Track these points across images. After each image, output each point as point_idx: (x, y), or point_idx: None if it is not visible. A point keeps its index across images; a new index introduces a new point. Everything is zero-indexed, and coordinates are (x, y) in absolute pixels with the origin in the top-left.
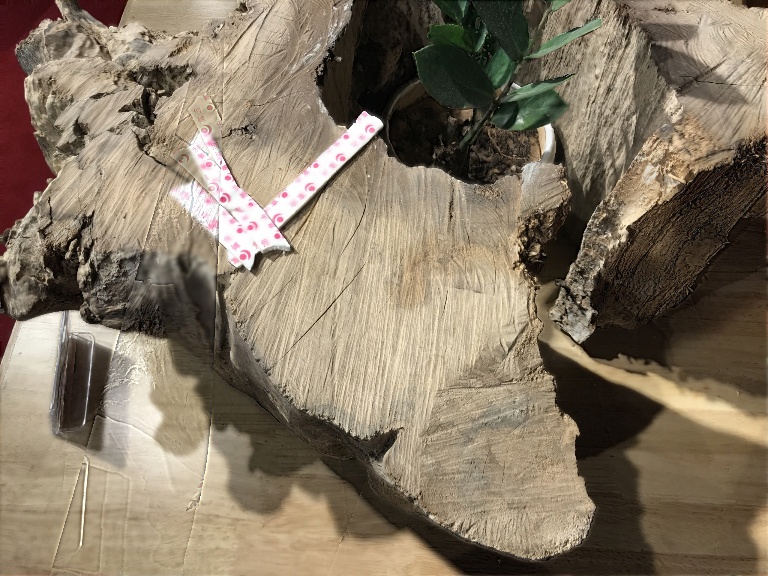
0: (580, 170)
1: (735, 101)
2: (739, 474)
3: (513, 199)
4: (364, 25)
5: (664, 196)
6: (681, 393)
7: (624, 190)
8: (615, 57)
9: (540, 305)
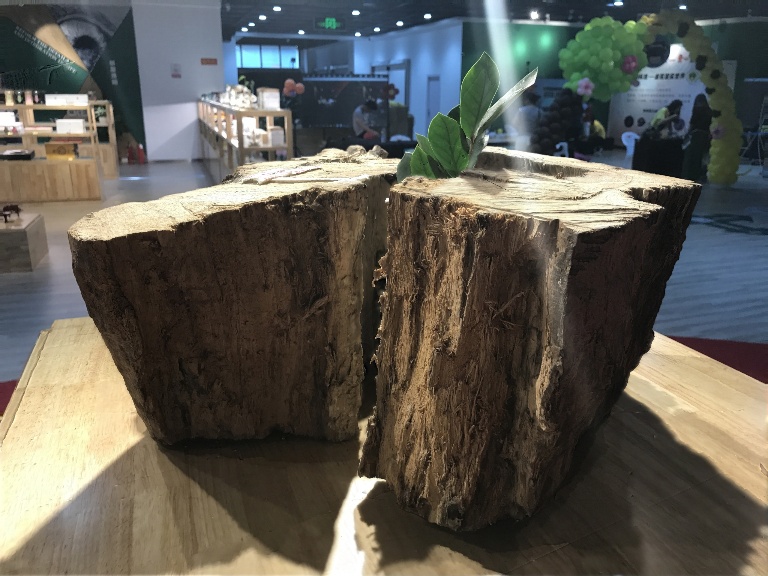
0: None
1: (488, 192)
2: None
3: None
4: None
5: None
6: None
7: None
8: None
9: None
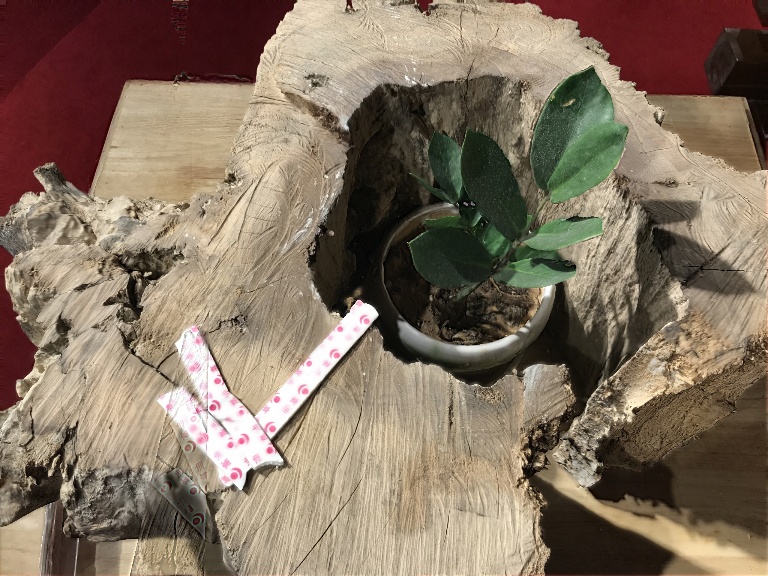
0: (581, 311)
1: (742, 290)
2: None
3: (515, 403)
4: (357, 172)
5: (671, 389)
6: (691, 538)
7: (629, 374)
8: (615, 224)
9: None
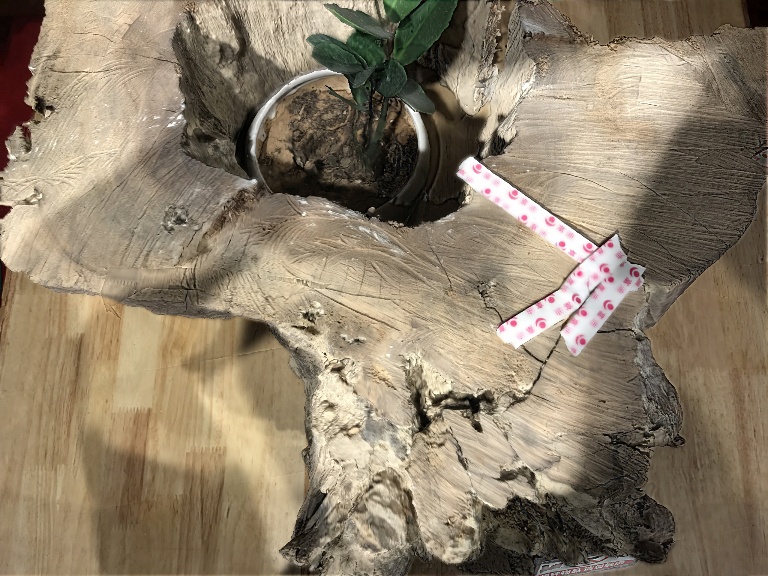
0: None
1: None
2: (582, 1)
3: (548, 47)
4: None
5: None
6: None
7: None
8: None
9: (455, 126)
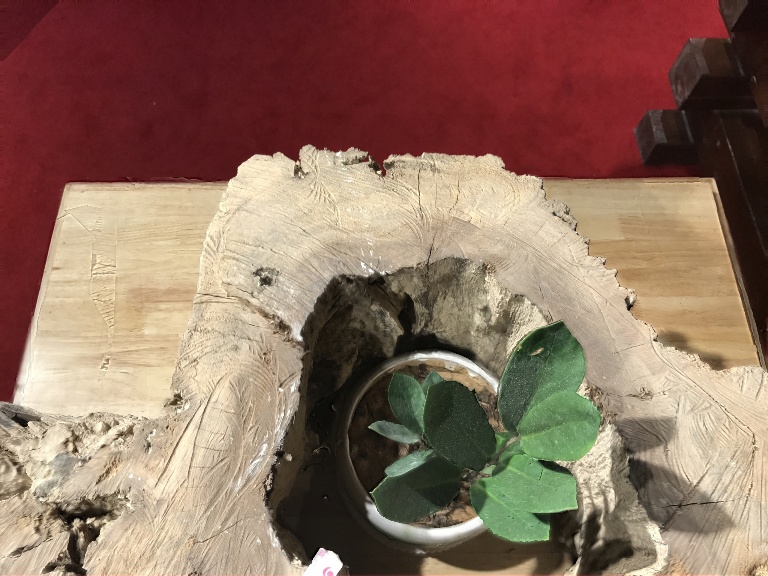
0: None
1: (722, 525)
2: None
3: None
4: (315, 349)
5: None
6: None
7: None
8: None
9: None
